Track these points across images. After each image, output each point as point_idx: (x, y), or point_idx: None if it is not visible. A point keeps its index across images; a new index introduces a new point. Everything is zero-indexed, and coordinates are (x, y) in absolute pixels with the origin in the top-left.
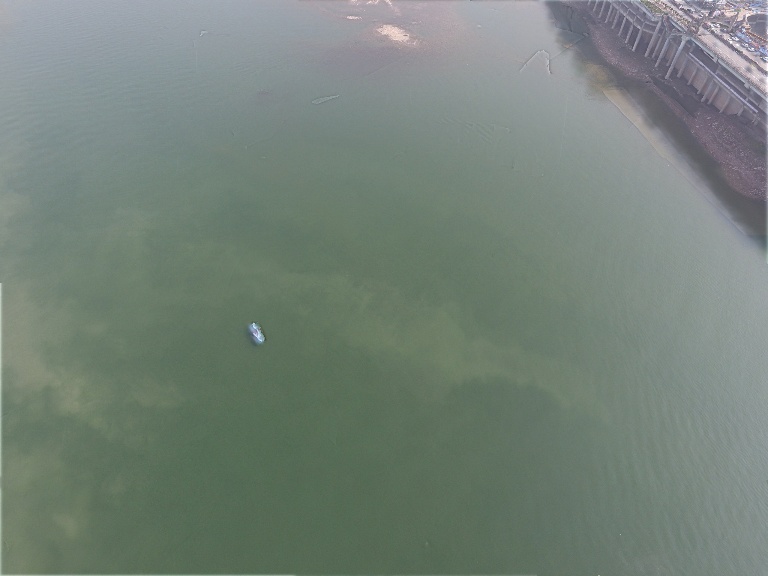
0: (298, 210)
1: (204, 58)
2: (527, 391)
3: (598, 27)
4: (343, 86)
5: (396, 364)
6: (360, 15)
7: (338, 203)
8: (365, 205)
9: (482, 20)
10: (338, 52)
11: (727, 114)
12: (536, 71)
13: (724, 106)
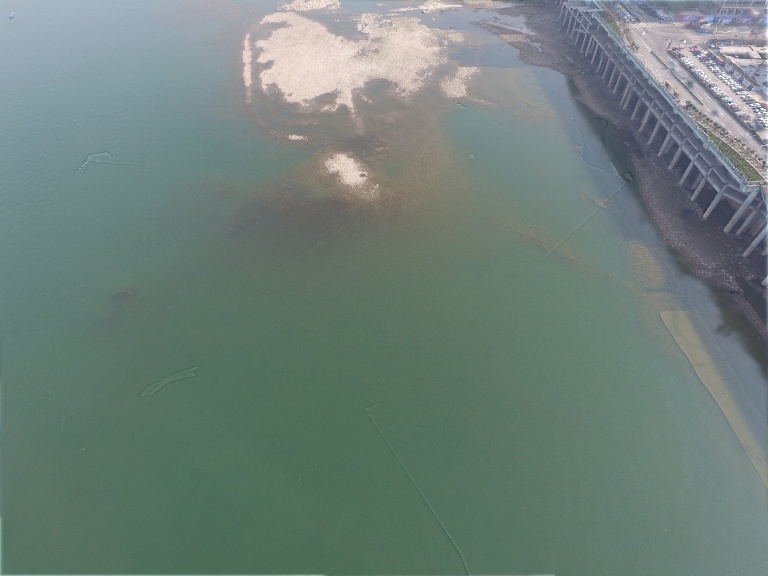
0: None
1: (59, 222)
2: None
3: (647, 164)
4: (251, 278)
5: None
6: (307, 133)
7: None
8: None
9: (477, 144)
10: (258, 208)
11: None
12: None
13: None
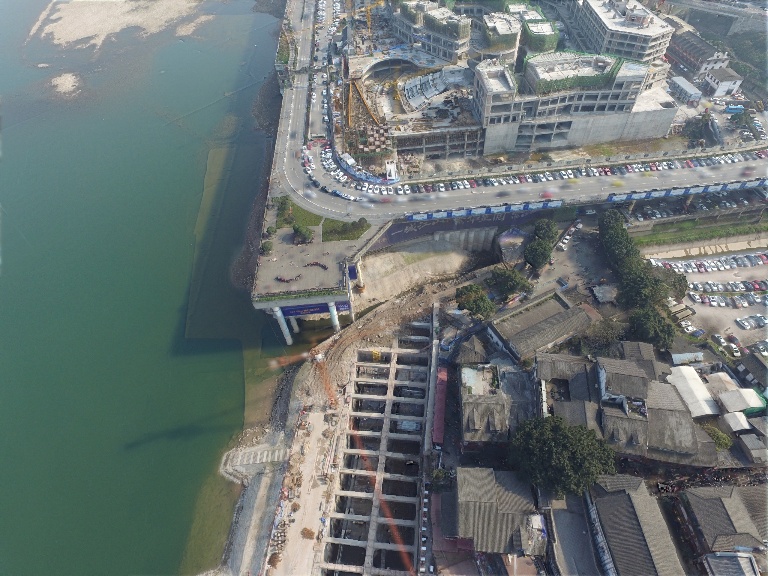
0: None
1: None
2: None
3: None
4: None
5: None
6: (54, 62)
7: None
8: None
9: (174, 64)
10: None
11: None
12: None
13: None
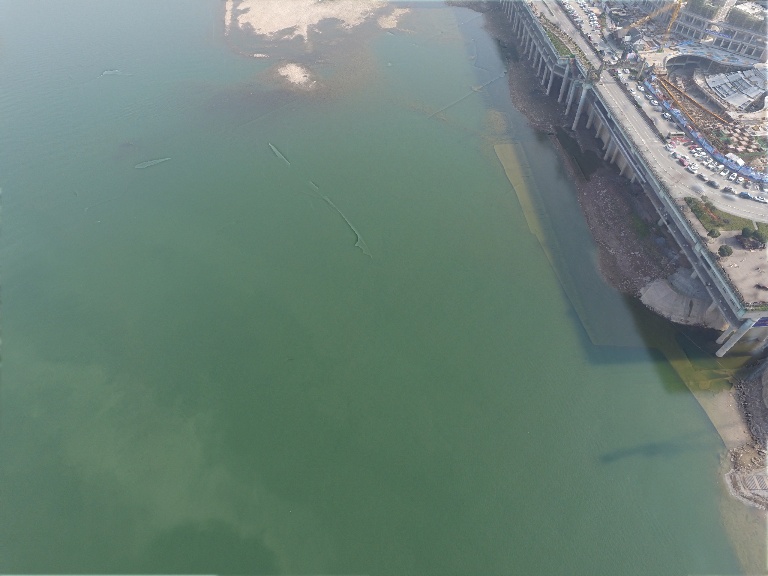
0: (90, 294)
1: (82, 105)
2: (239, 563)
3: (519, 65)
4: (217, 136)
5: (103, 511)
6: (268, 52)
7: (143, 284)
8: (177, 285)
9: (396, 57)
10: (226, 96)
11: (627, 177)
12: (286, 161)
13: (623, 168)
